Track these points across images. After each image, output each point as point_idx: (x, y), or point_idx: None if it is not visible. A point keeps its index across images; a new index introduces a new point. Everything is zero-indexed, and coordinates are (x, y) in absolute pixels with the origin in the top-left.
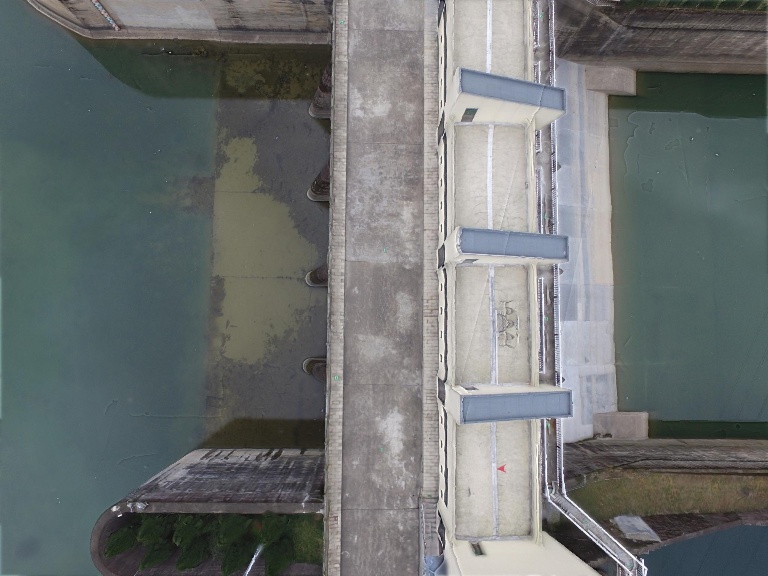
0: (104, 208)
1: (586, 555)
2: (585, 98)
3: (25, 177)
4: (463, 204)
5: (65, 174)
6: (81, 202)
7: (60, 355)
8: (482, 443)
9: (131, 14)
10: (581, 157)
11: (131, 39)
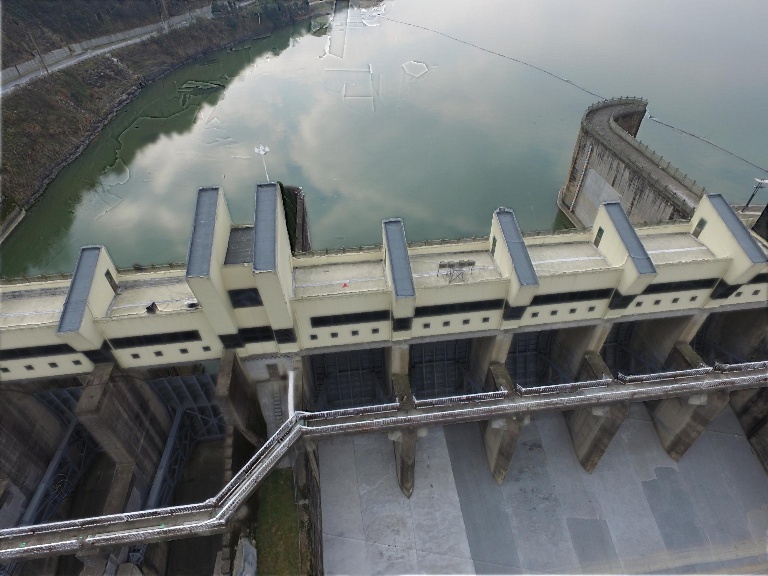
0: (459, 223)
1: (236, 462)
2: (767, 567)
3: (465, 197)
4: (534, 250)
5: (473, 208)
6: (459, 216)
7: (368, 217)
8: (363, 274)
9: (582, 208)
10: (688, 568)
11: (569, 218)
